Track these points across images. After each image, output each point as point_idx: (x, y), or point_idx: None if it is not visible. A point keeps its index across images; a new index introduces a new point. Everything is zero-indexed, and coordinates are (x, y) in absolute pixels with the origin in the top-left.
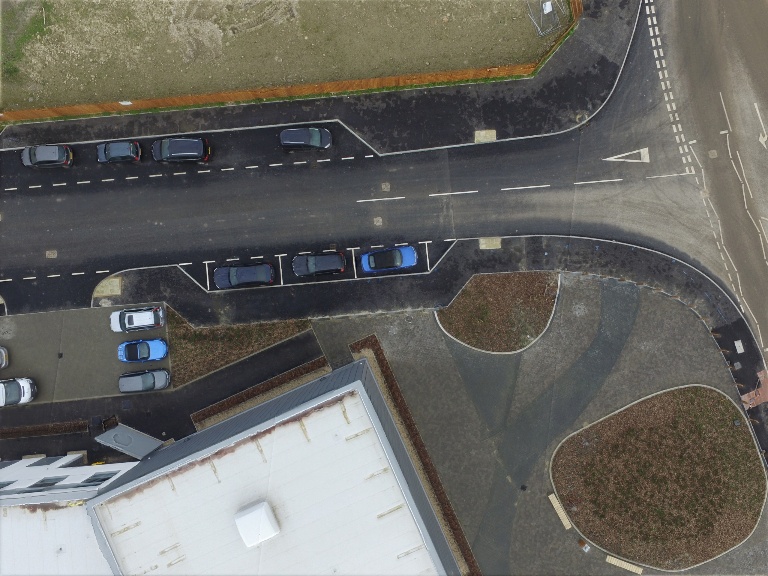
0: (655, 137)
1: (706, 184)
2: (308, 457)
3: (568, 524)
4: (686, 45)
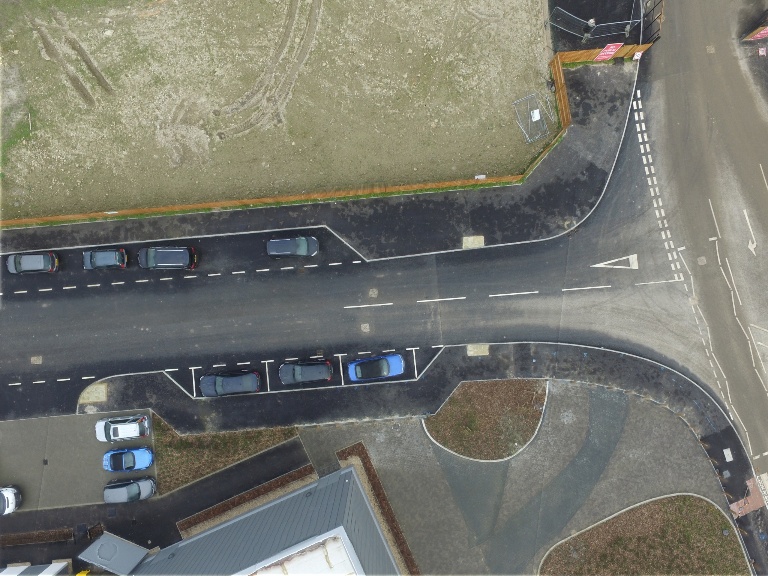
0: (644, 243)
1: (695, 291)
2: None
3: None
4: (675, 152)
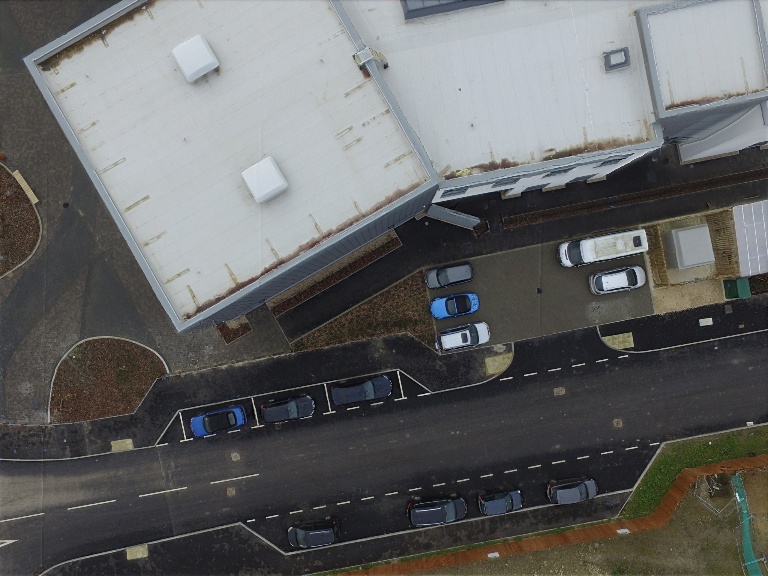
0: None
1: None
2: (225, 248)
3: (16, 176)
4: None
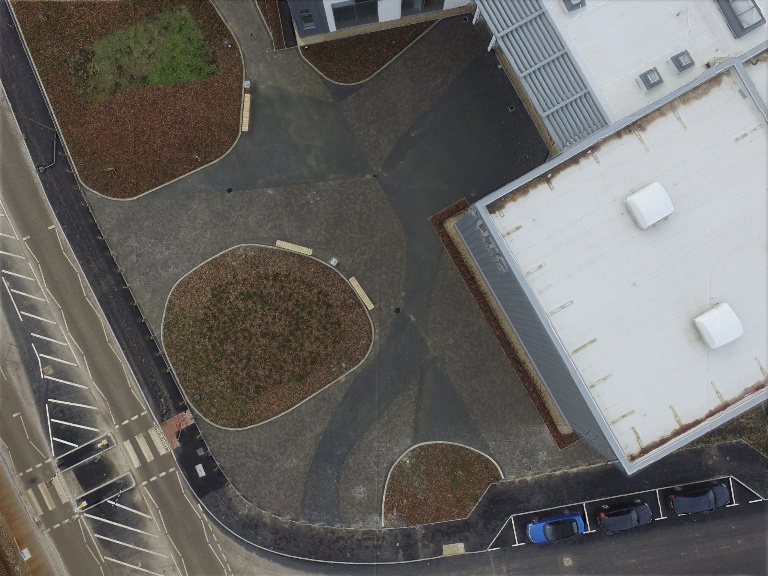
0: None
1: None
2: (670, 391)
3: (353, 282)
4: None
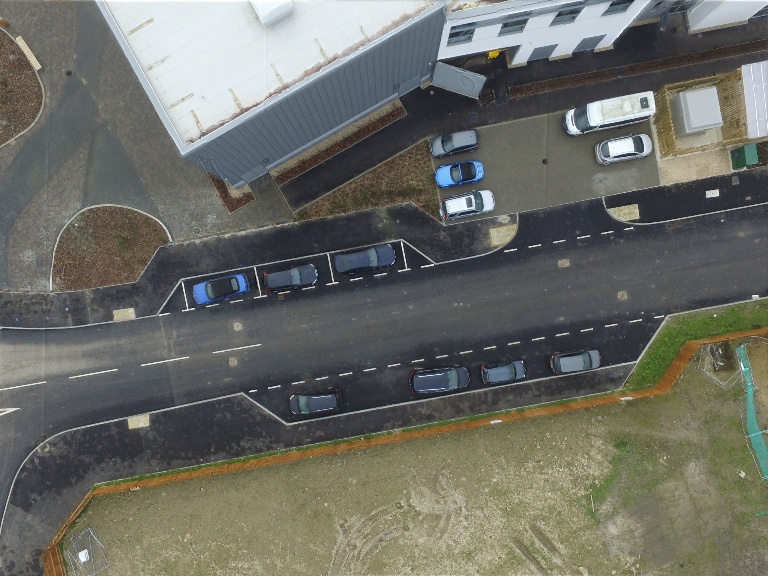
0: None
1: None
2: (229, 73)
3: (19, 41)
4: None
